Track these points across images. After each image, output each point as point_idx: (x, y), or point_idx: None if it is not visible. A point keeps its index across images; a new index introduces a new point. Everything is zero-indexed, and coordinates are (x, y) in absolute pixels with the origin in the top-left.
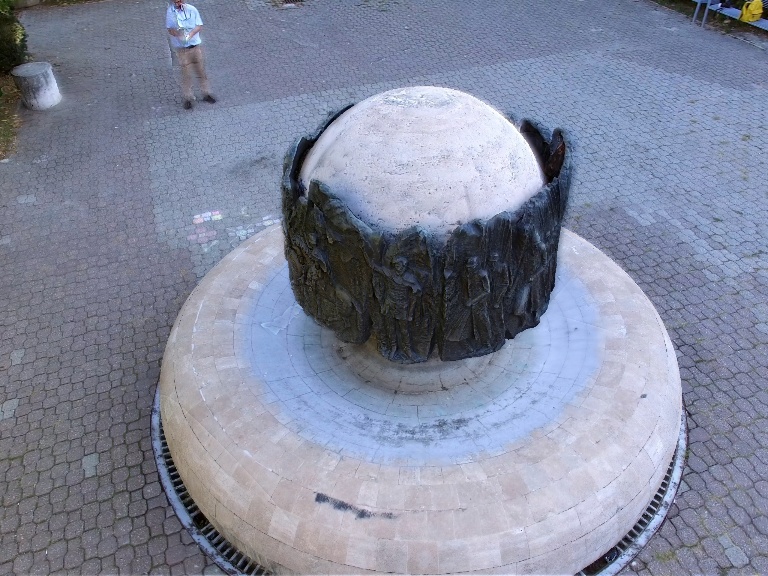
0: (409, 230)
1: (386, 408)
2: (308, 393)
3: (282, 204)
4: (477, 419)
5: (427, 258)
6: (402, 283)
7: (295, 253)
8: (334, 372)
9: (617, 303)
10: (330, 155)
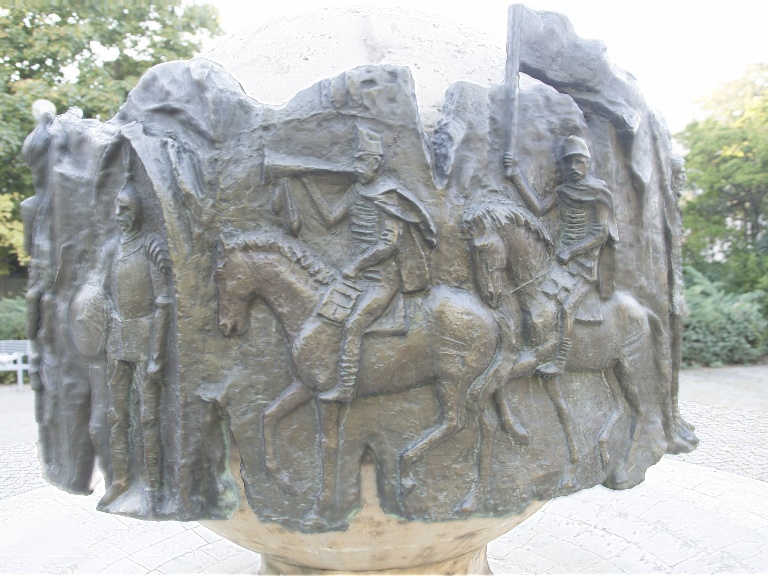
0: (654, 107)
1: None
2: None
3: (379, 135)
4: (670, 567)
5: None
6: None
7: (456, 288)
8: None
9: None
10: (397, 29)
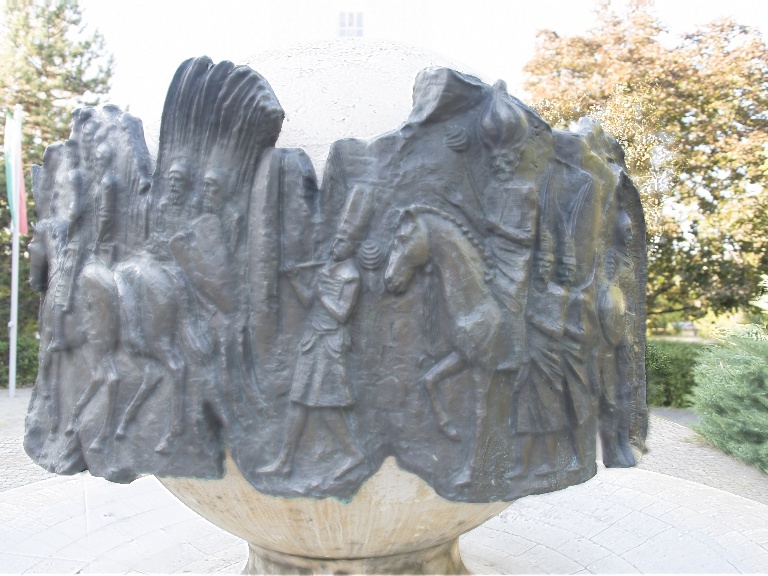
0: None
1: (471, 532)
2: (598, 534)
3: None
4: None
5: None
6: None
7: None
8: (553, 575)
9: (8, 500)
10: None
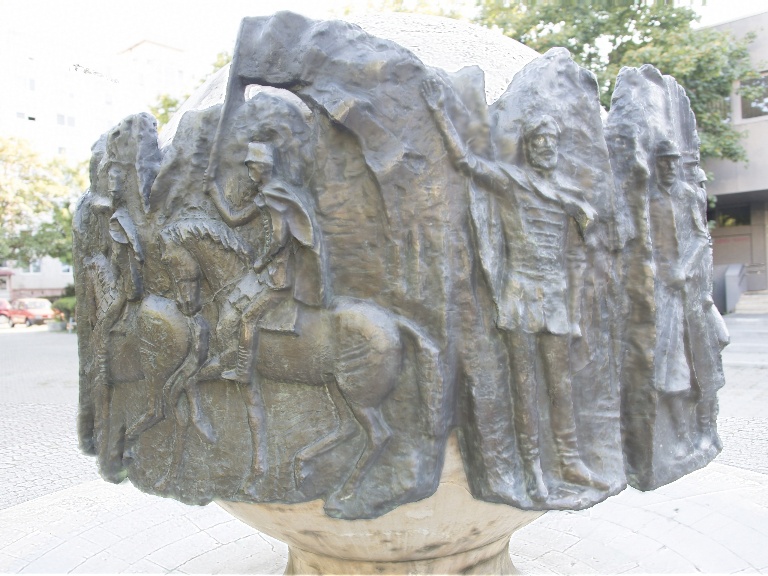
0: None
1: None
2: None
3: (115, 175)
4: None
5: (597, 123)
6: (556, 197)
7: (159, 297)
8: None
9: None
10: None
